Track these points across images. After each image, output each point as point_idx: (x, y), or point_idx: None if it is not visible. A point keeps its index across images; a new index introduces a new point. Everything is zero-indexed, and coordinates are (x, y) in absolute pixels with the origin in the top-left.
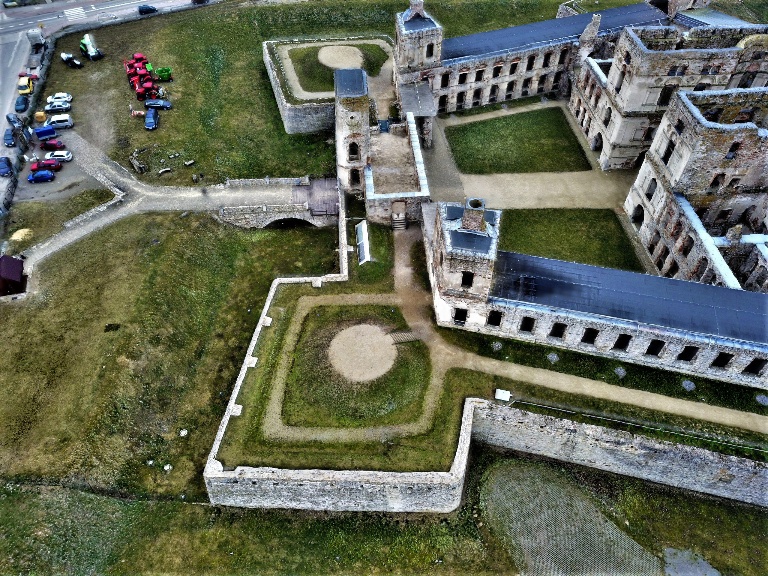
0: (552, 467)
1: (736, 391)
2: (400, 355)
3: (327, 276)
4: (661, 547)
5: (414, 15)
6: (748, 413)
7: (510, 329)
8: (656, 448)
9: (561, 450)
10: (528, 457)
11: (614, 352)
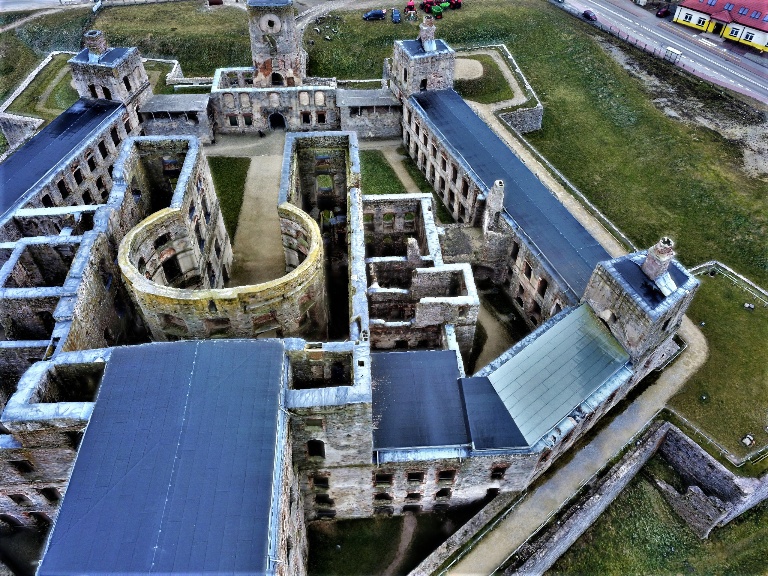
0: None
1: None
2: None
3: (169, 74)
4: None
5: None
6: None
7: None
8: None
9: None
10: None
11: None
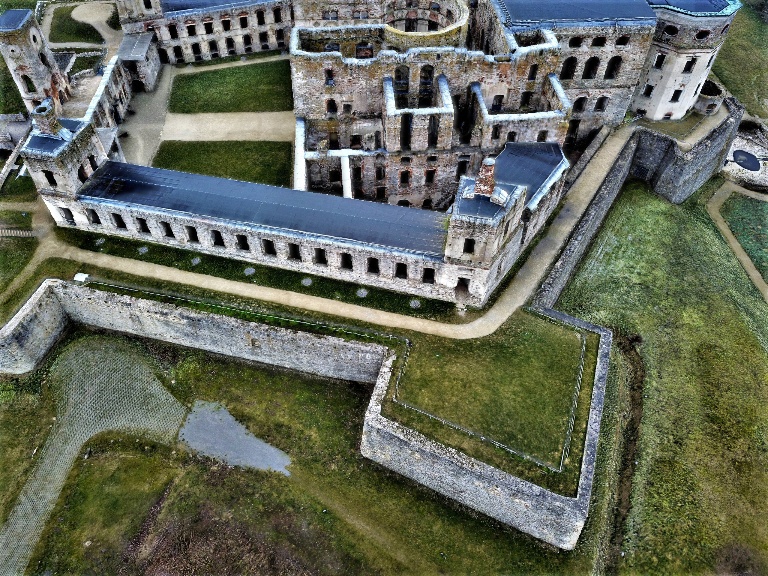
0: (129, 340)
1: (287, 275)
2: (1, 245)
3: None
4: (193, 399)
5: None
6: (287, 291)
7: (108, 226)
8: (191, 316)
9: (134, 325)
10: (113, 333)
11: (191, 244)
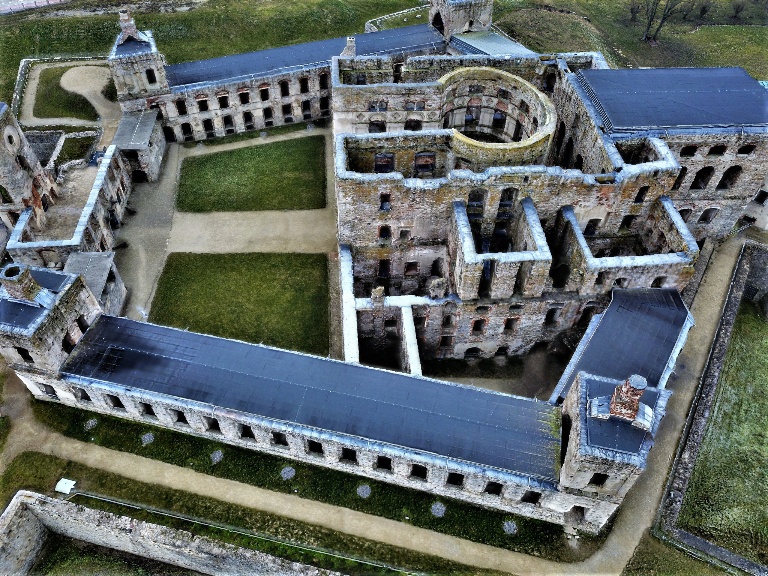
0: (128, 566)
1: (338, 480)
2: None
3: None
4: None
5: (127, 38)
6: (339, 508)
7: (102, 406)
8: (212, 553)
9: (135, 548)
10: (107, 553)
11: (211, 434)
